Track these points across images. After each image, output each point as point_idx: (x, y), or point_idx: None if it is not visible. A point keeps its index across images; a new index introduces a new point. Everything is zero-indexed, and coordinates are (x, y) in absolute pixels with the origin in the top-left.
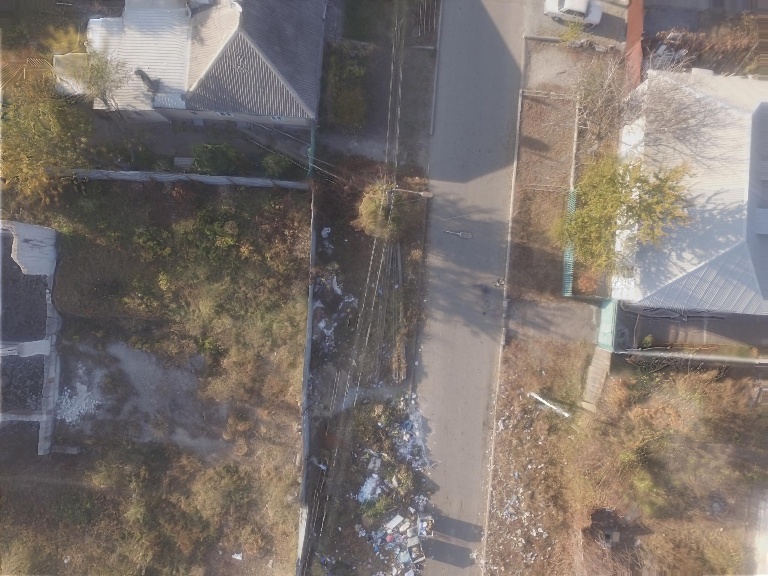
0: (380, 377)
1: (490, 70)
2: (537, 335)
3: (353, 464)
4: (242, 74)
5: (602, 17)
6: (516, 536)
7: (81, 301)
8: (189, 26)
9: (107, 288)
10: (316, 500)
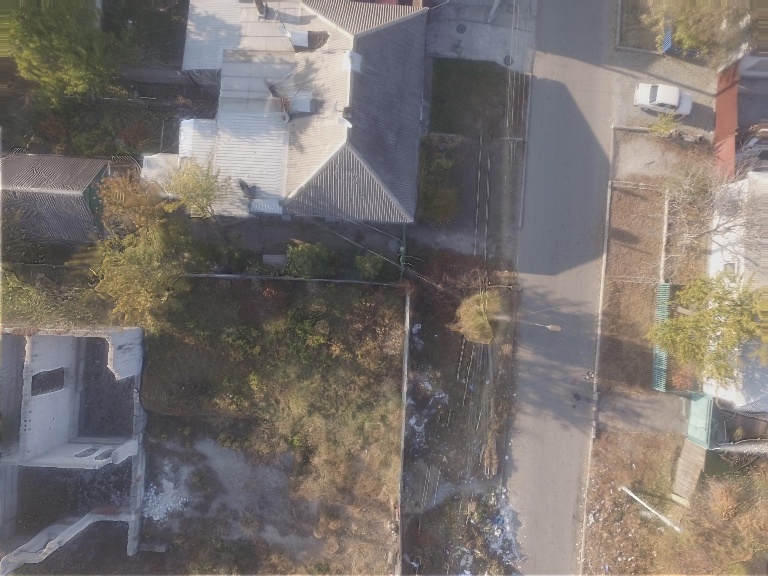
0: (471, 473)
1: (578, 161)
2: (626, 427)
3: (445, 561)
4: (344, 183)
5: (692, 108)
6: None
7: (169, 400)
8: (286, 131)
9: (198, 389)
10: None
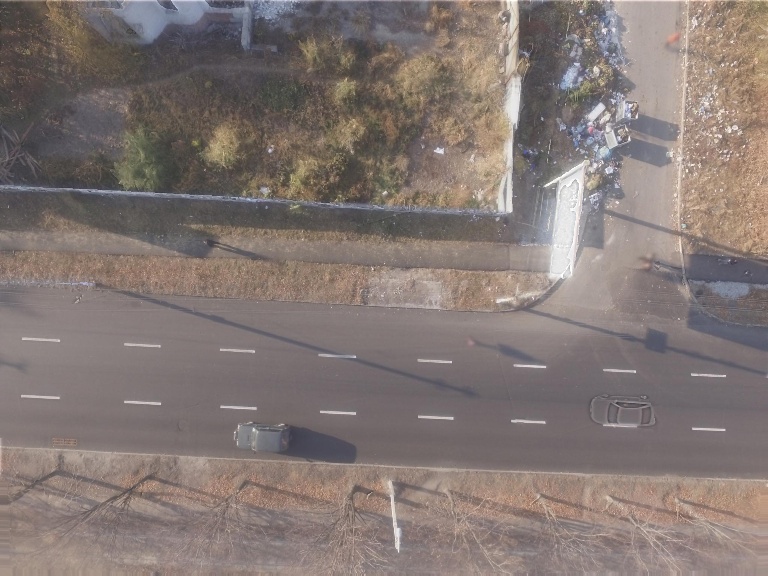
0: None
1: None
2: None
3: (556, 51)
4: None
5: None
6: (712, 132)
7: None
8: None
9: None
10: None
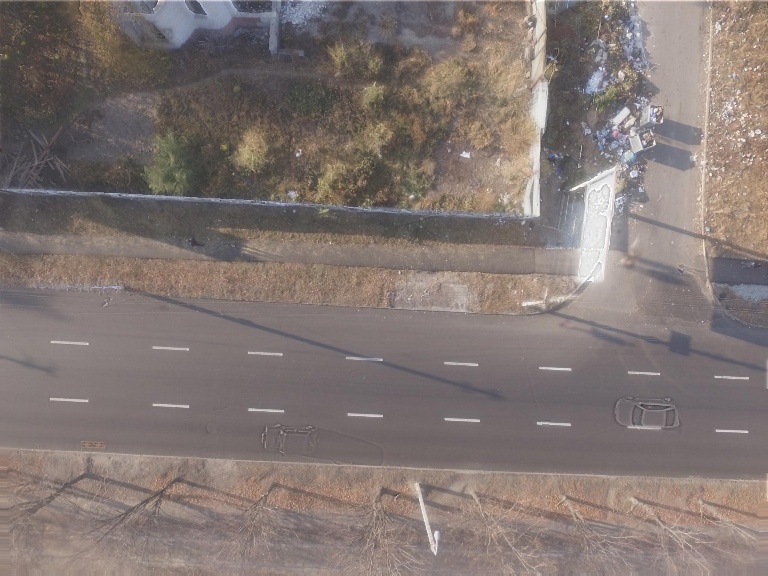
0: None
1: None
2: None
3: (581, 56)
4: None
5: None
6: (735, 137)
7: None
8: None
9: None
10: None
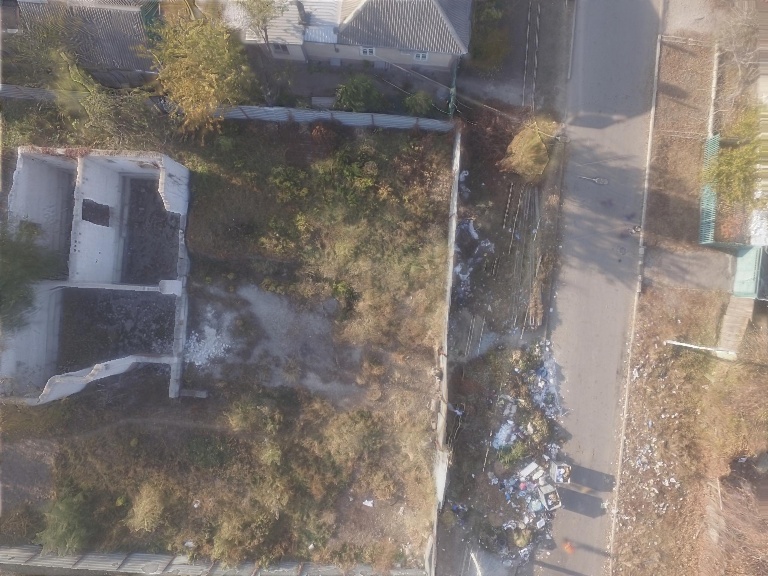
0: (516, 323)
1: (628, 15)
2: (672, 283)
3: (489, 410)
4: (402, 5)
5: None
6: (648, 486)
7: (215, 242)
8: None
9: (245, 227)
10: (450, 446)
